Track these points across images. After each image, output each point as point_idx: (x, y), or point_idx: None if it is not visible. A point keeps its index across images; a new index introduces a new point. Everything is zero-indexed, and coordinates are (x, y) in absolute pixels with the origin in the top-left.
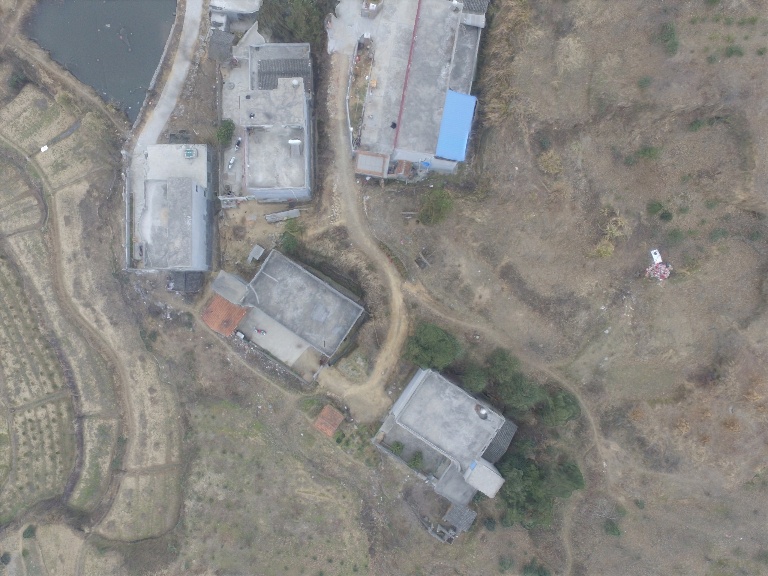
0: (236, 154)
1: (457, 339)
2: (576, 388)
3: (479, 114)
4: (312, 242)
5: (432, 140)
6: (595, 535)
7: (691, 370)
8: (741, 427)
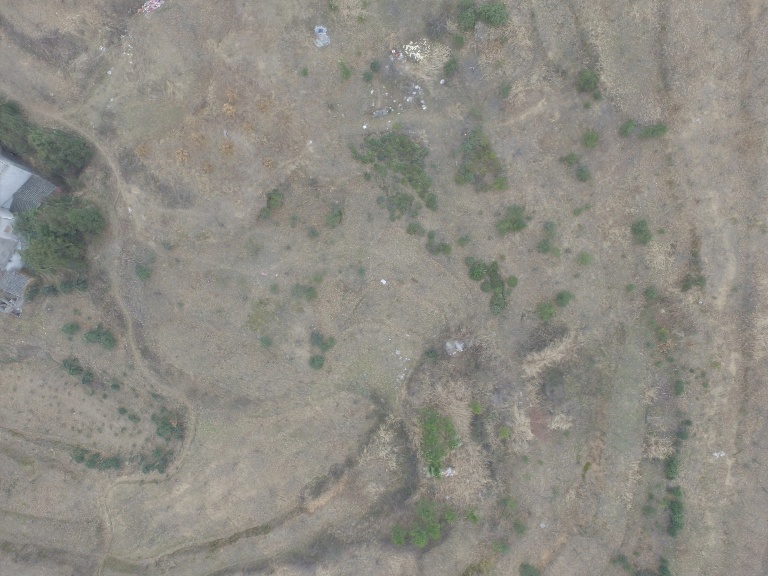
0: None
1: None
2: (92, 135)
3: None
4: None
5: None
6: (136, 285)
7: (196, 104)
8: (238, 150)
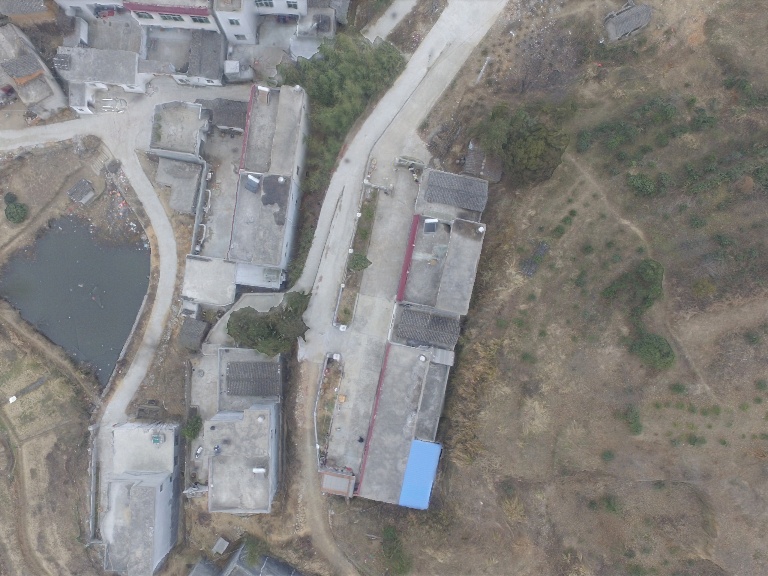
0: None
1: None
2: None
3: (445, 456)
4: (276, 549)
5: (396, 489)
6: None
7: None
8: None
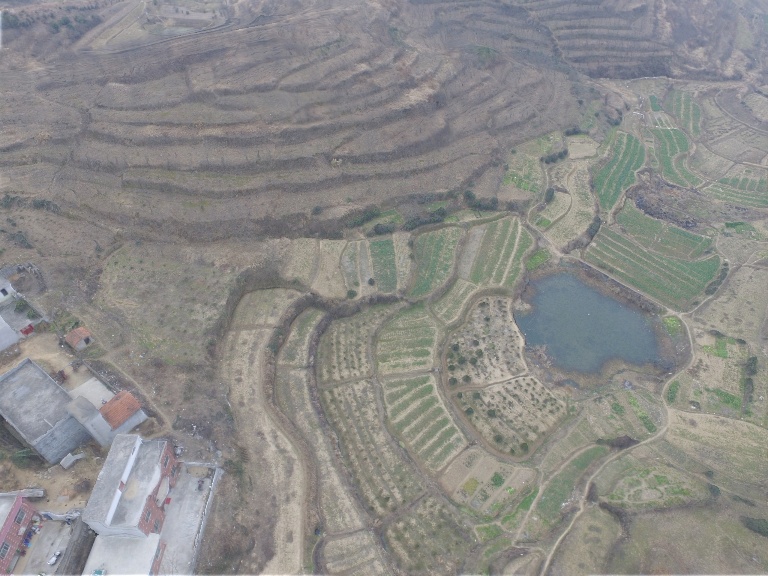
0: (47, 570)
1: None
2: None
3: None
4: None
5: None
6: None
7: None
8: None
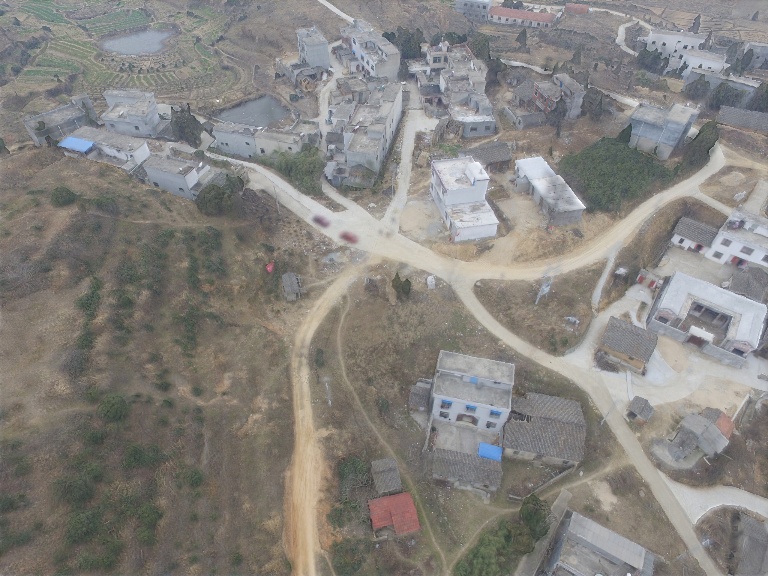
0: None
1: None
2: None
3: None
4: None
5: None
6: None
7: None
8: None
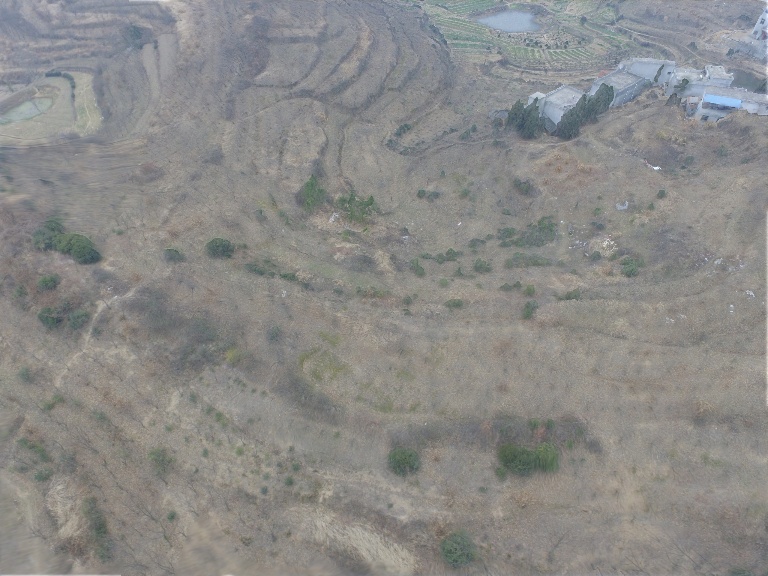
0: None
1: (602, 114)
2: None
3: None
4: None
5: (713, 94)
6: None
7: None
8: None
